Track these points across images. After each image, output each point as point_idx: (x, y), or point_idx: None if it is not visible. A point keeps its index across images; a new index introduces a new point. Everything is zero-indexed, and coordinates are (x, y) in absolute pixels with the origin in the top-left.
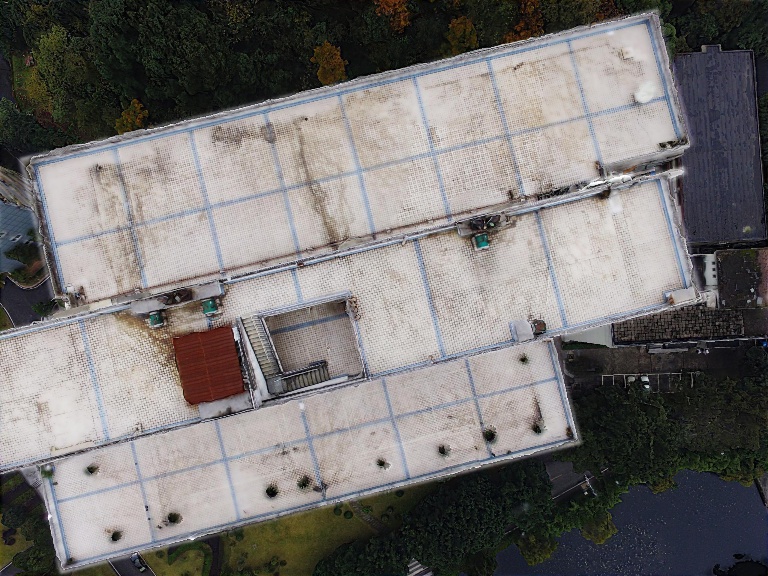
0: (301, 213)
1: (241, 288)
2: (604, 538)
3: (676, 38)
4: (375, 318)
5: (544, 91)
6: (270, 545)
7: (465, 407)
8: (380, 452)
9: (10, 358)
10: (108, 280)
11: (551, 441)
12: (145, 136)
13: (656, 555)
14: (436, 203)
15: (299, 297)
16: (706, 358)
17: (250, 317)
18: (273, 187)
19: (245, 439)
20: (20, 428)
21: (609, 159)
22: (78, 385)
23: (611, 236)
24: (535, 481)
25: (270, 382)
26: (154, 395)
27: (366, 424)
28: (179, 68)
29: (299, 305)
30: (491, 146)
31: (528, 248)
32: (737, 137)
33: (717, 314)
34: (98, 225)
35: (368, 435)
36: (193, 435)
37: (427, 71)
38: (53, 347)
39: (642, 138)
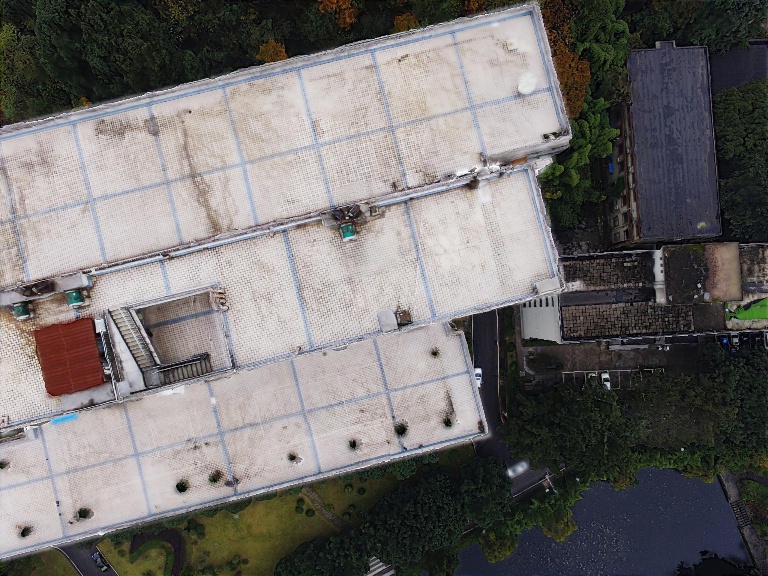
0: (184, 206)
1: (109, 280)
2: (564, 535)
3: (629, 34)
4: (243, 309)
5: (428, 83)
6: (232, 544)
7: (377, 401)
8: (292, 446)
9: None
10: None
11: (463, 435)
12: (26, 129)
13: (619, 552)
14: (320, 195)
15: (167, 289)
16: (667, 354)
17: (118, 309)
18: (156, 180)
19: (156, 434)
20: None
21: (493, 150)
22: None
23: (480, 226)
24: (493, 478)
25: (147, 374)
26: (21, 387)
27: (278, 418)
28: (122, 66)
29: (166, 296)
30: (375, 138)
31: (397, 239)
32: (691, 133)
33: (666, 310)
34: None
35: (280, 429)
36: (104, 430)
37: (310, 63)
38: None
39: (526, 129)
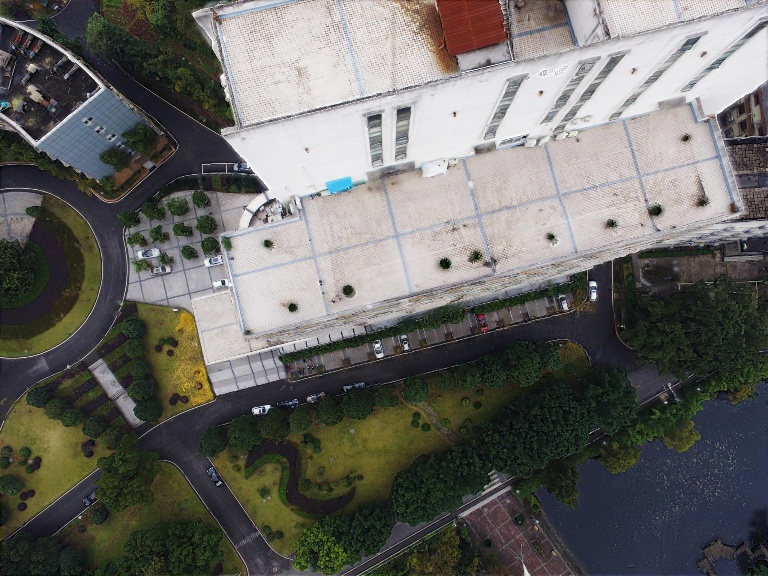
0: None
1: None
2: (689, 443)
3: None
4: None
5: None
6: (347, 459)
7: (630, 185)
8: (548, 228)
9: (271, 26)
10: None
11: None
12: None
13: (736, 470)
14: None
15: None
16: None
17: None
18: None
19: (416, 216)
20: (281, 90)
21: None
22: (335, 52)
23: None
24: (620, 381)
25: None
26: (408, 61)
27: (533, 202)
28: None
29: None
30: None
31: None
32: None
33: None
34: None
35: (536, 212)
36: (365, 212)
37: None
38: (311, 17)
39: None
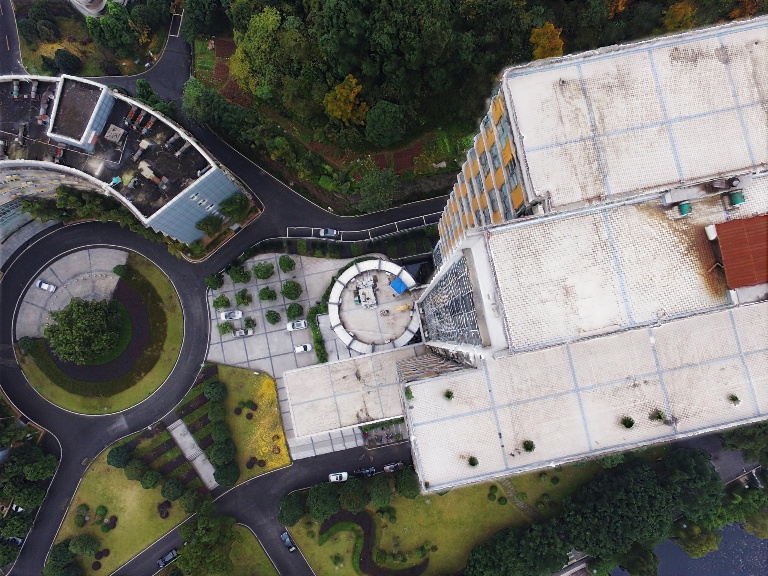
0: (755, 130)
1: (755, 185)
2: None
3: None
4: None
5: None
6: (422, 529)
7: None
8: (730, 388)
9: (539, 243)
10: (573, 186)
11: None
12: (613, 52)
13: None
14: None
15: None
16: None
17: (764, 212)
18: (727, 105)
19: (597, 370)
20: (549, 310)
21: None
22: (603, 271)
23: None
24: (708, 469)
25: None
26: (676, 283)
27: (715, 360)
28: (412, 42)
29: None
30: None
31: None
32: None
33: None
34: (562, 135)
35: (717, 371)
36: (546, 364)
37: None
38: (578, 234)
39: None
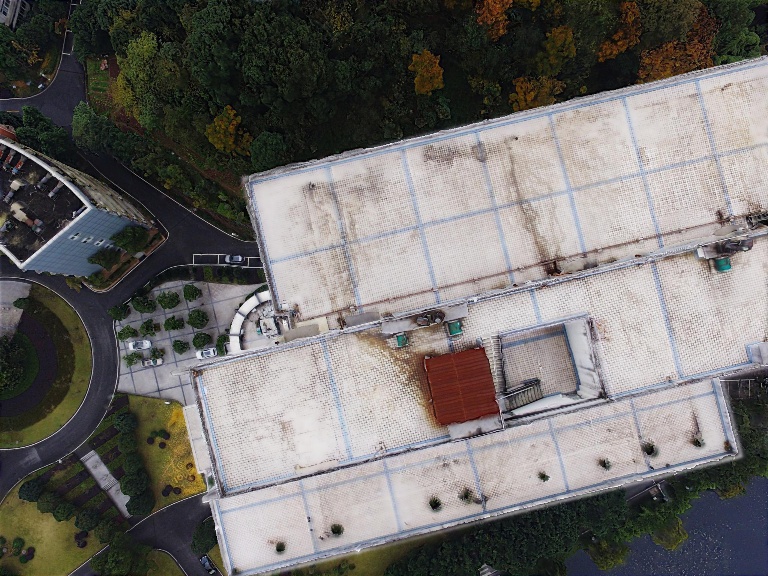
0: (512, 232)
1: (481, 309)
2: (676, 543)
3: (759, 47)
4: (613, 339)
5: (751, 112)
6: None
7: (623, 420)
8: (539, 465)
9: (254, 377)
10: (322, 297)
11: (709, 454)
12: (361, 155)
13: (721, 560)
14: (646, 223)
15: (538, 318)
16: None
17: (489, 337)
18: (485, 206)
19: None
20: (265, 446)
21: None
22: (321, 404)
23: None
24: None
25: None
26: (396, 414)
27: (525, 437)
28: (282, 75)
29: (540, 326)
30: (699, 166)
31: (763, 270)
32: None
33: None
34: (312, 243)
35: (527, 448)
36: None
37: (637, 91)
38: (296, 366)
39: None
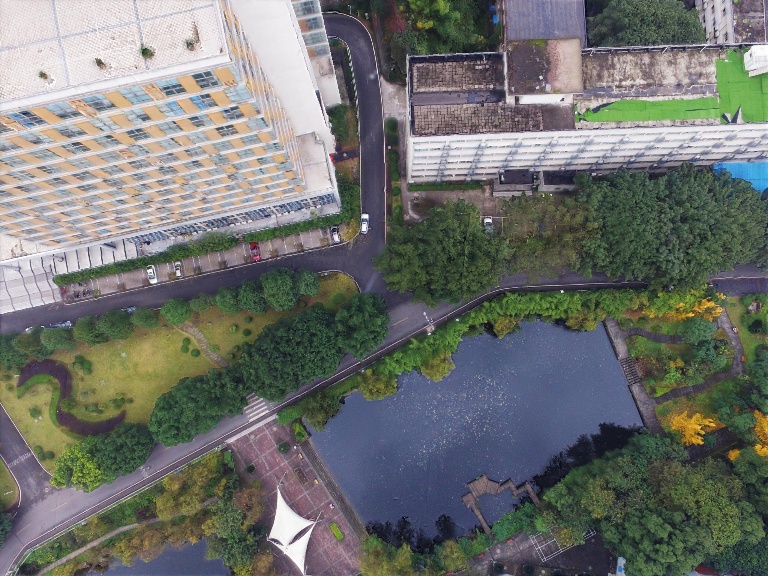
0: None
1: None
2: (439, 370)
3: None
4: None
5: None
6: (118, 382)
7: (128, 30)
8: (45, 69)
9: None
10: None
11: None
12: None
13: (506, 406)
14: None
15: None
16: (550, 202)
17: None
18: None
19: None
20: None
21: None
22: None
23: None
24: None
25: None
26: None
27: (35, 43)
28: None
29: None
30: None
31: None
32: None
33: (516, 111)
34: None
35: (36, 53)
36: None
37: None
38: None
39: None
